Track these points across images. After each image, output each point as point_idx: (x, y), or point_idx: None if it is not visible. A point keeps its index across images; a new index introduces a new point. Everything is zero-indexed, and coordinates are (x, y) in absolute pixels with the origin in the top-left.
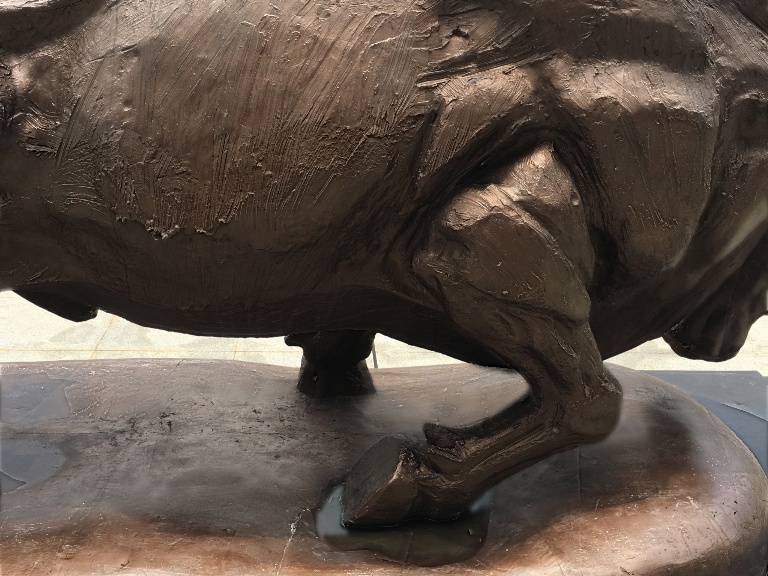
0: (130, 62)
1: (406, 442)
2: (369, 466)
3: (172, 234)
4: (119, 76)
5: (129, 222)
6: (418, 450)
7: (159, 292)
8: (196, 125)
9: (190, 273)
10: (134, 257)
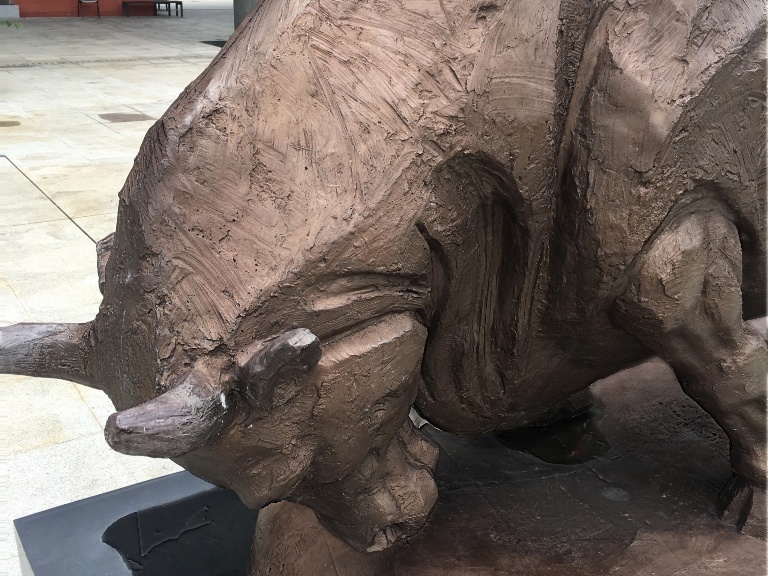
0: None
1: None
2: None
3: None
4: None
5: None
6: None
7: None
8: None
9: None
10: None
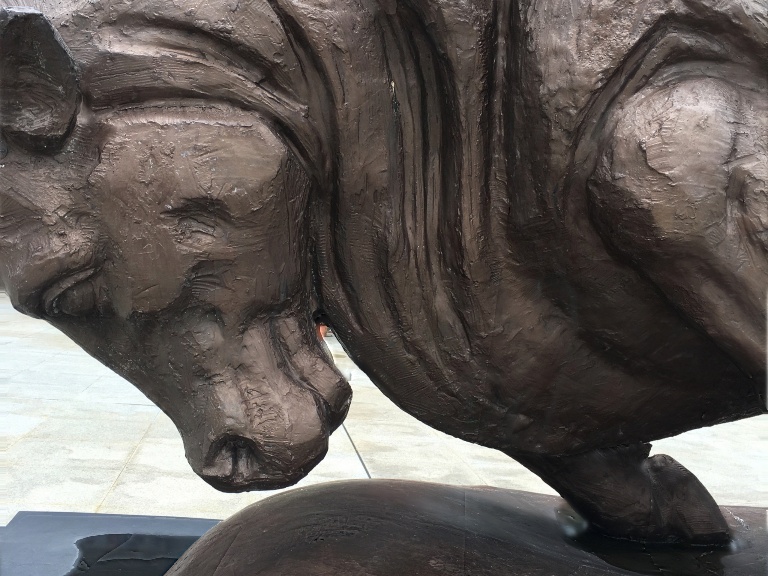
0: None
1: (664, 461)
2: None
3: None
4: None
5: None
6: (647, 459)
7: None
8: None
9: None
10: None
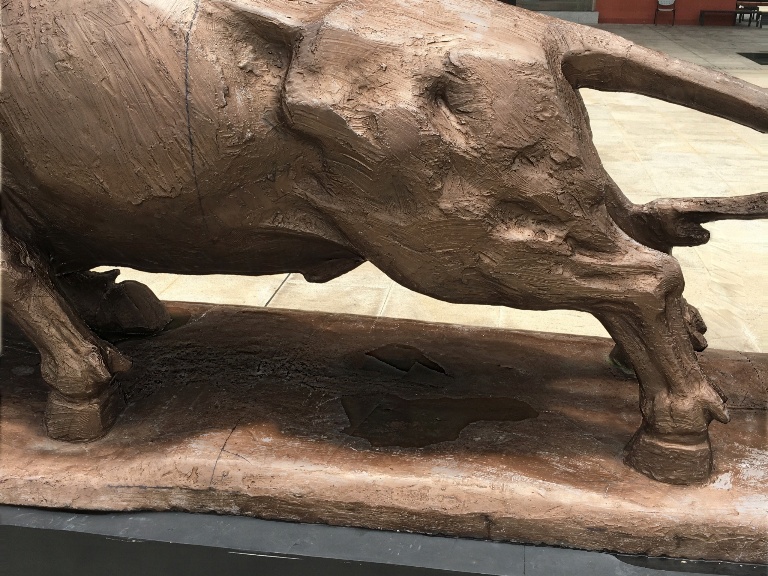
0: None
1: (120, 285)
2: (144, 304)
3: None
4: None
5: None
6: None
7: None
8: None
9: None
10: None
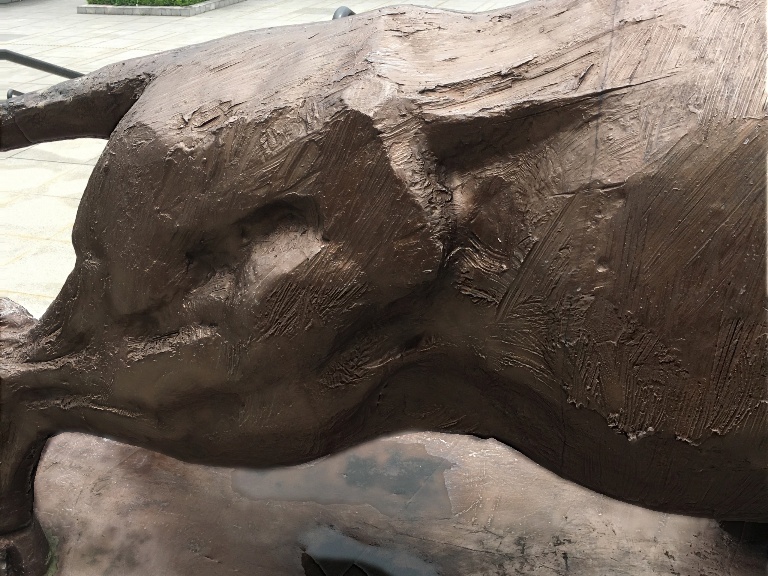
0: (612, 205)
1: None
2: None
3: (643, 436)
4: (594, 222)
5: (585, 409)
6: None
7: (603, 477)
8: (697, 301)
9: (652, 473)
10: (580, 440)
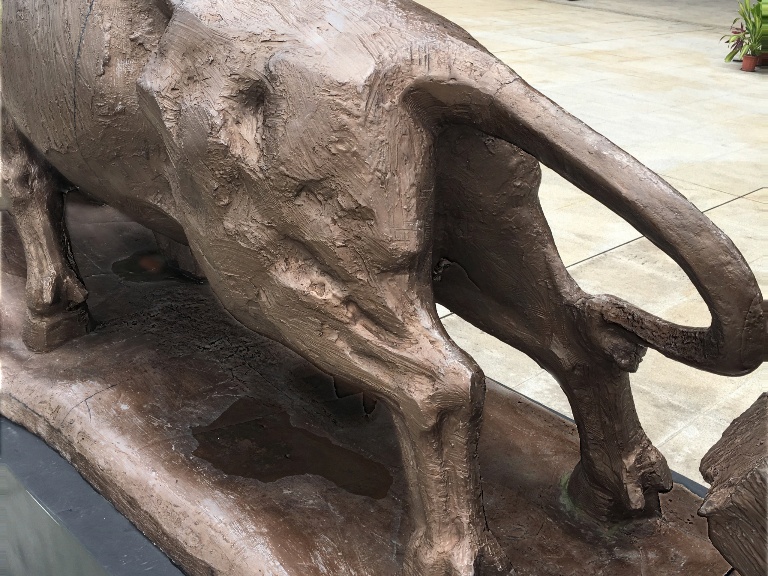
0: None
1: None
2: None
3: None
4: None
5: None
6: None
7: None
8: None
9: None
10: None
